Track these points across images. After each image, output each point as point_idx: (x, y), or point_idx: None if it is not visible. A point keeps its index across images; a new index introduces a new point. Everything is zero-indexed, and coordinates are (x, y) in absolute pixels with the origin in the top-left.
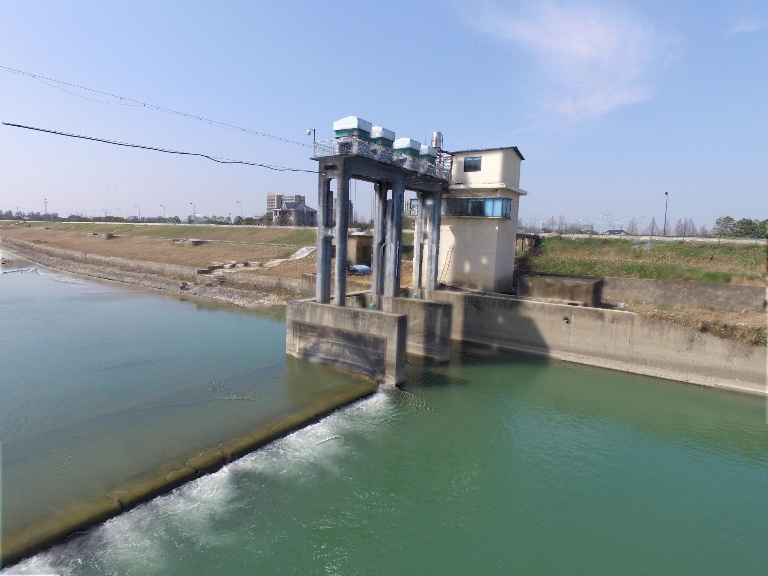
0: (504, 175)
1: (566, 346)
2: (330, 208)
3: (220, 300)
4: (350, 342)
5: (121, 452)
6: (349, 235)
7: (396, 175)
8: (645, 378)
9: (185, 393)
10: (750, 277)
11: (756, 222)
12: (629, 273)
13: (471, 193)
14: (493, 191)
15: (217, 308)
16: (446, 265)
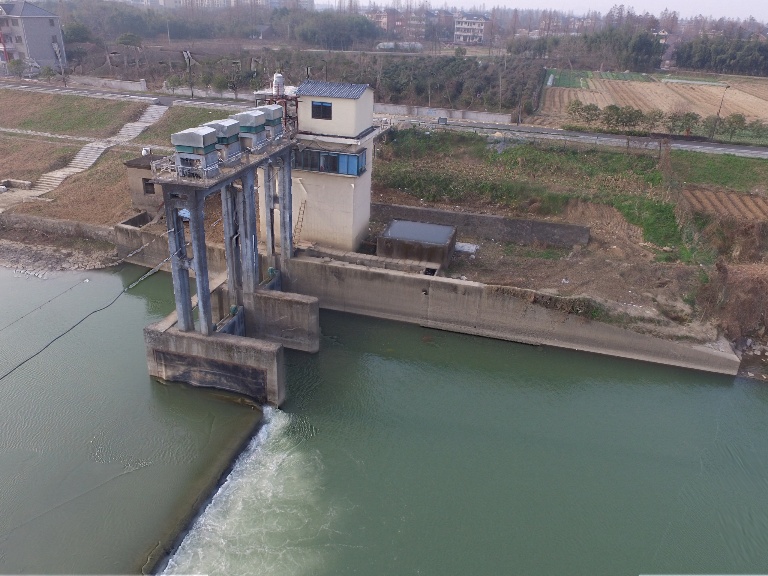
0: (358, 124)
1: (425, 314)
2: (183, 236)
3: (4, 268)
4: (227, 372)
5: (72, 574)
6: None
7: None
8: (490, 340)
9: (78, 475)
10: (584, 199)
11: (601, 107)
12: (482, 193)
13: (323, 148)
14: (347, 146)
15: (7, 285)
16: (299, 222)
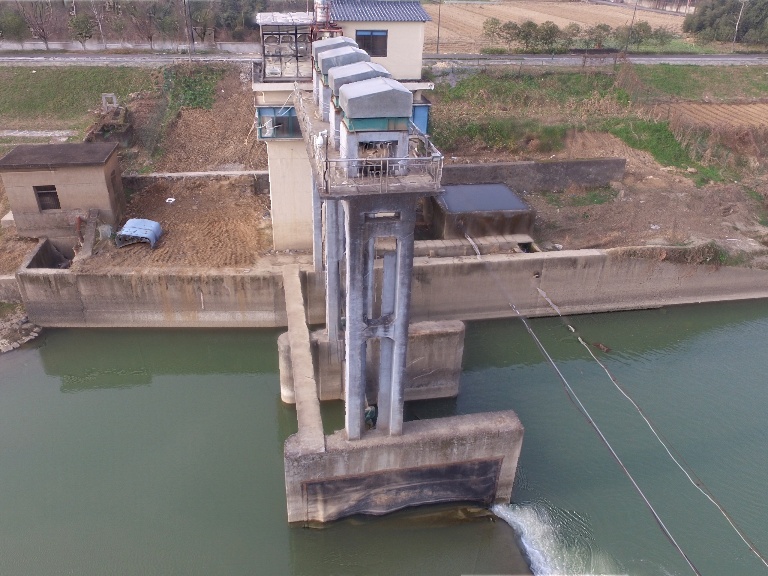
0: None
1: (534, 302)
2: None
3: None
4: (435, 479)
5: None
6: (84, 163)
7: None
8: (608, 315)
9: None
10: (580, 129)
11: (519, 25)
12: (472, 137)
13: None
14: None
15: None
16: None
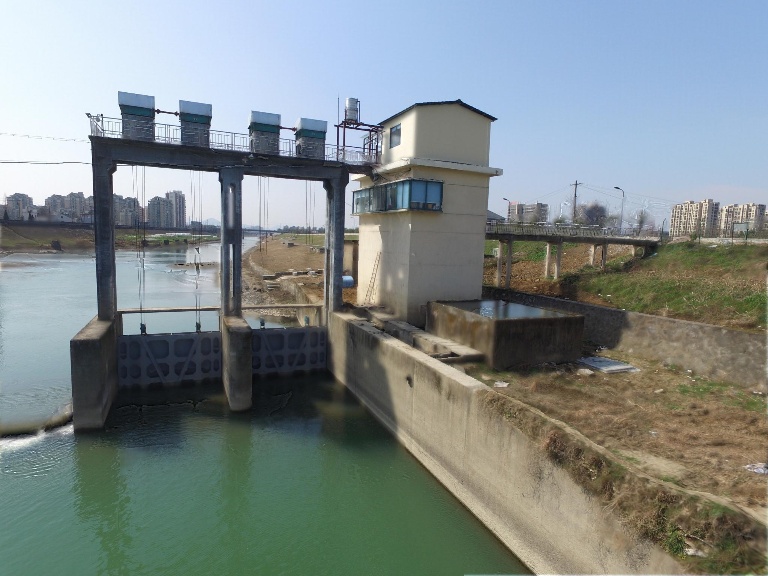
0: (428, 146)
1: (409, 426)
2: None
3: None
4: None
5: None
6: None
7: (218, 159)
8: (479, 528)
9: None
10: None
11: None
12: (742, 310)
13: (384, 177)
14: (405, 171)
15: None
16: (372, 279)
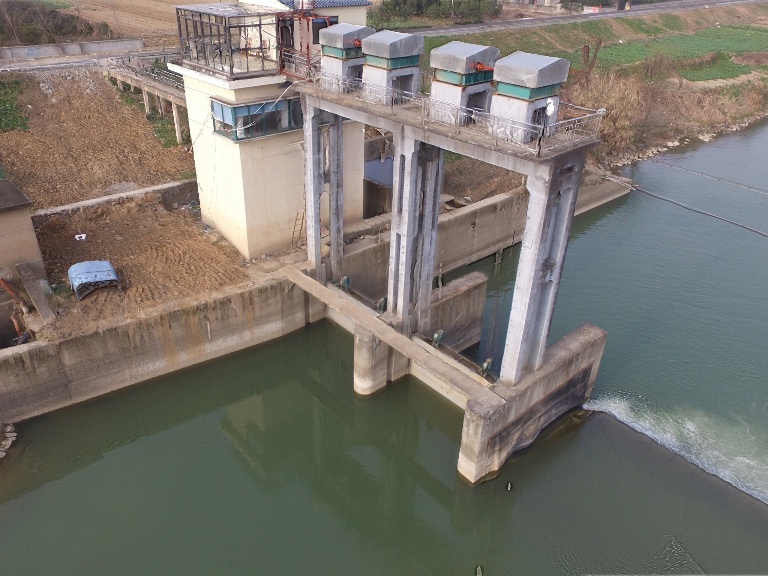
0: None
1: (471, 250)
2: None
3: None
4: None
5: None
6: (6, 208)
7: None
8: None
9: None
10: None
11: None
12: None
13: None
14: None
15: None
16: None
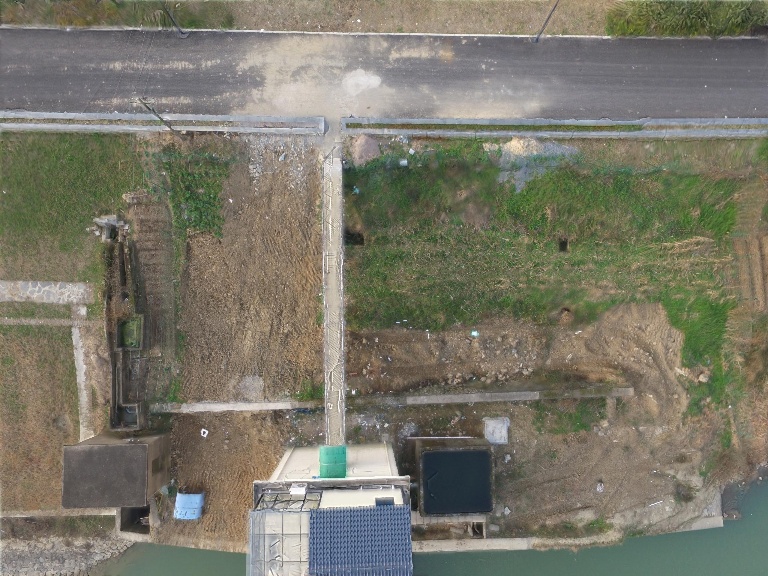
0: None
1: None
2: None
3: None
4: None
5: None
6: None
7: None
8: None
9: None
10: None
11: None
12: (502, 308)
13: None
14: None
15: None
16: None
